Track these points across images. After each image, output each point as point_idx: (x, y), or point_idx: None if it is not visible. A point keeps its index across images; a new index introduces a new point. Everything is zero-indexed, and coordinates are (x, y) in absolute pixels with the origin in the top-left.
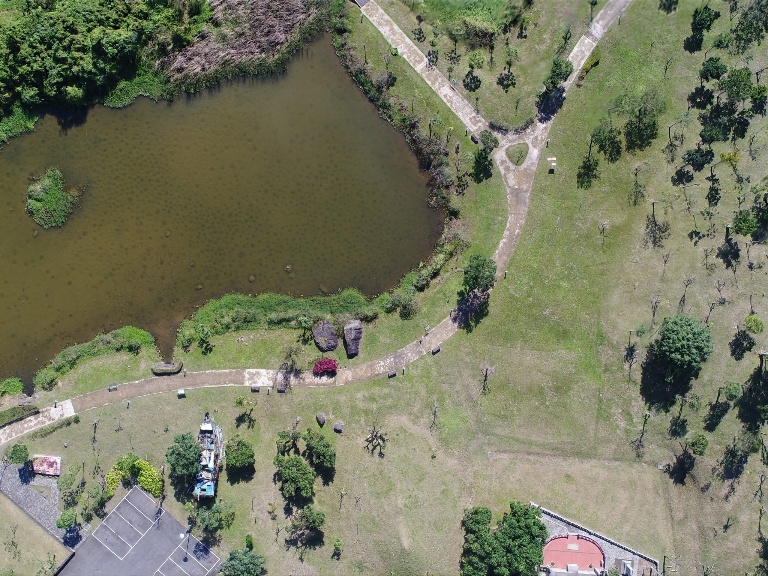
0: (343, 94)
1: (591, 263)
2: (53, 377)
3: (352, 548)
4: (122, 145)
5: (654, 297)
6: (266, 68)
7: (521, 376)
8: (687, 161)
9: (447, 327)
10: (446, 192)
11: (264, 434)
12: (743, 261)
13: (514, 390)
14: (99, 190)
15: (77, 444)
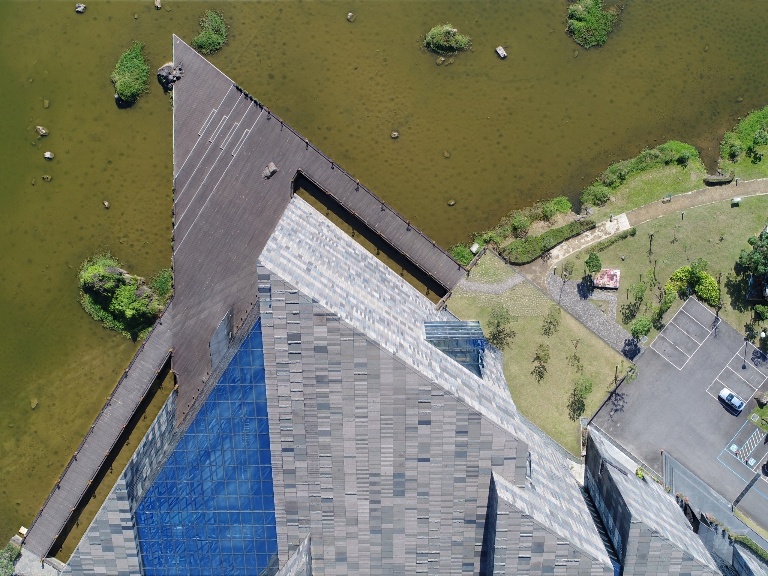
0: None
1: None
2: (610, 191)
3: None
4: None
5: None
6: None
7: None
8: None
9: None
10: None
11: None
12: None
13: None
14: (637, 8)
15: (633, 257)
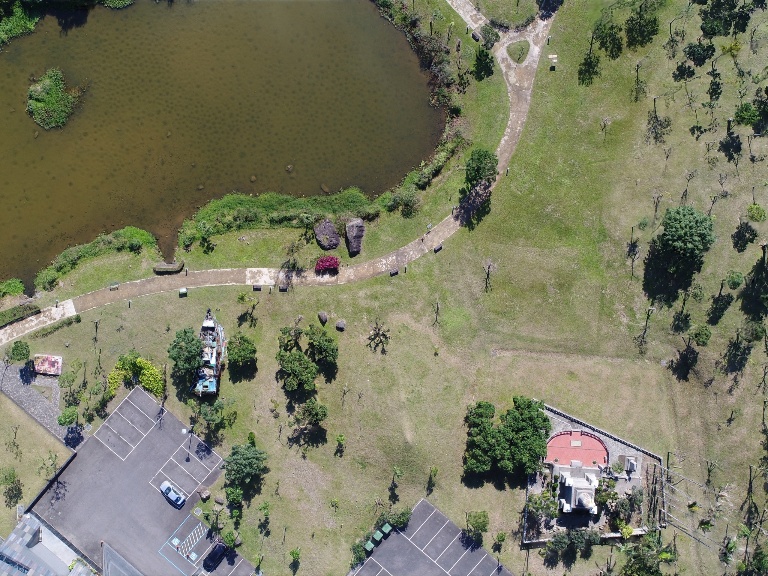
0: None
1: (593, 160)
2: (54, 276)
3: (355, 444)
4: (123, 46)
5: (656, 193)
6: None
7: (523, 273)
8: (688, 54)
9: (449, 225)
10: (447, 91)
11: (266, 333)
12: (745, 154)
13: (516, 287)
14: (100, 91)
15: (78, 344)
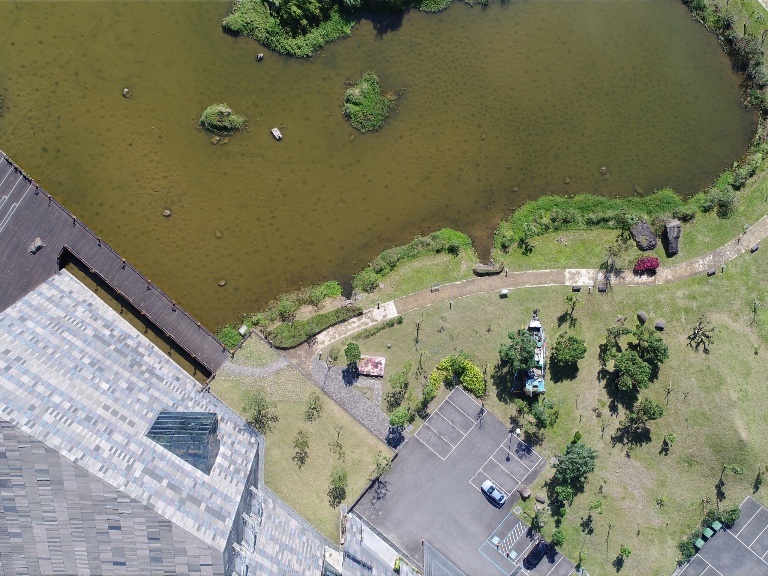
0: None
1: None
2: (377, 278)
3: (681, 443)
4: (437, 49)
5: None
6: None
7: None
8: None
9: (765, 225)
10: (760, 92)
11: (585, 333)
12: None
13: None
14: (415, 94)
15: (400, 345)
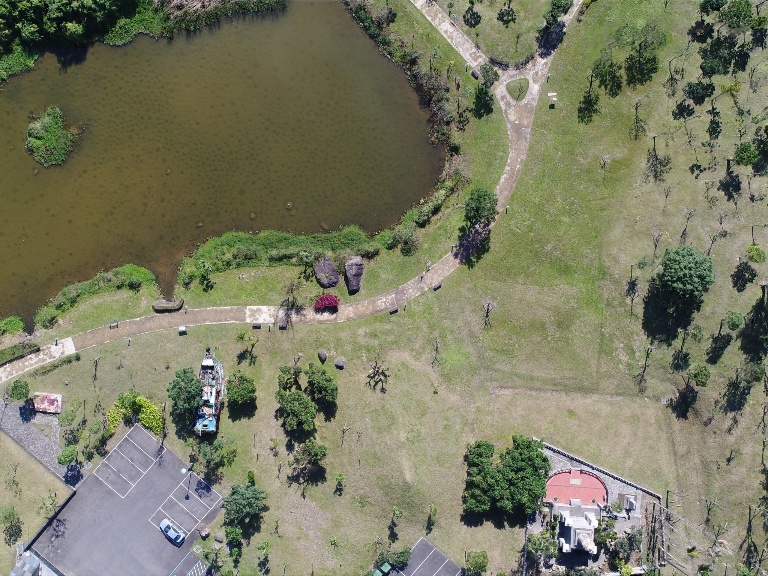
0: (343, 31)
1: (592, 198)
2: (54, 314)
3: (354, 483)
4: (122, 83)
5: (655, 231)
6: (266, 5)
7: (523, 311)
8: (688, 93)
9: (448, 263)
10: (447, 128)
11: (265, 371)
12: (744, 193)
13: (516, 325)
14: (99, 128)
15: (78, 382)
